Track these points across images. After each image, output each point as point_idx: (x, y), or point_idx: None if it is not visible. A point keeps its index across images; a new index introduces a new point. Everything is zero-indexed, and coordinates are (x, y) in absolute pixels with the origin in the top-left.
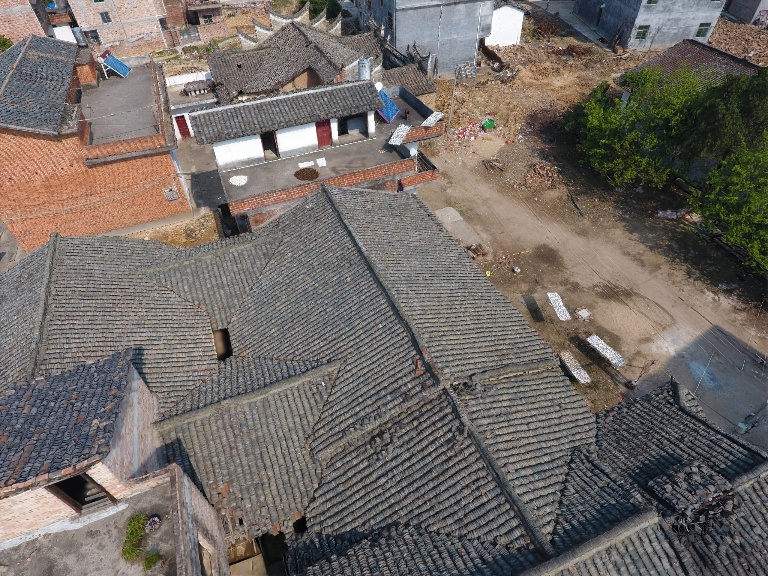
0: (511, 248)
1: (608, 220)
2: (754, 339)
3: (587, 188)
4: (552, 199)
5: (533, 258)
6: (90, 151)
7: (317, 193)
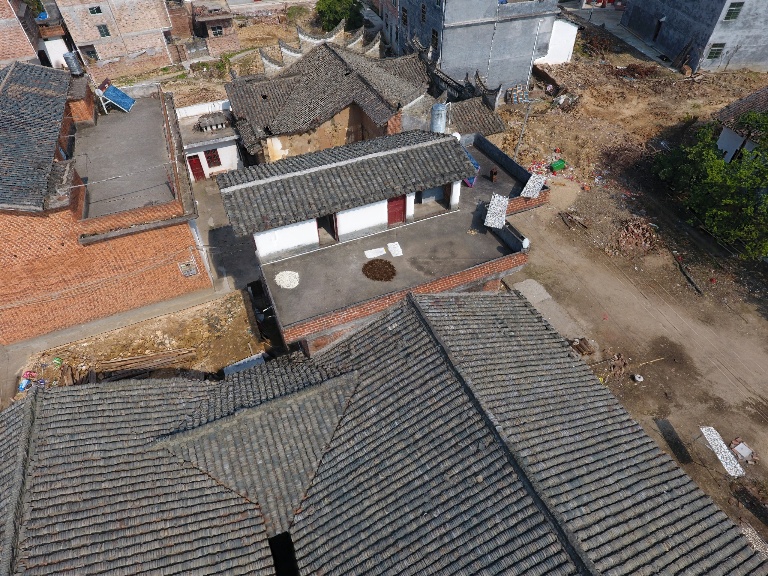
0: (622, 342)
1: (734, 301)
2: None
3: (696, 253)
4: (656, 269)
5: (653, 358)
6: (86, 226)
7: (401, 306)
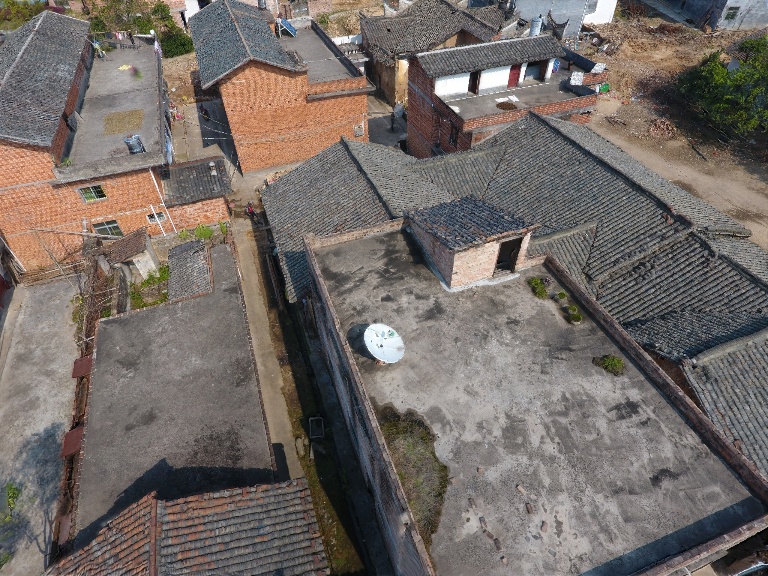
0: None
1: (729, 164)
2: None
3: (704, 140)
4: (676, 147)
5: None
6: (312, 88)
7: (526, 118)
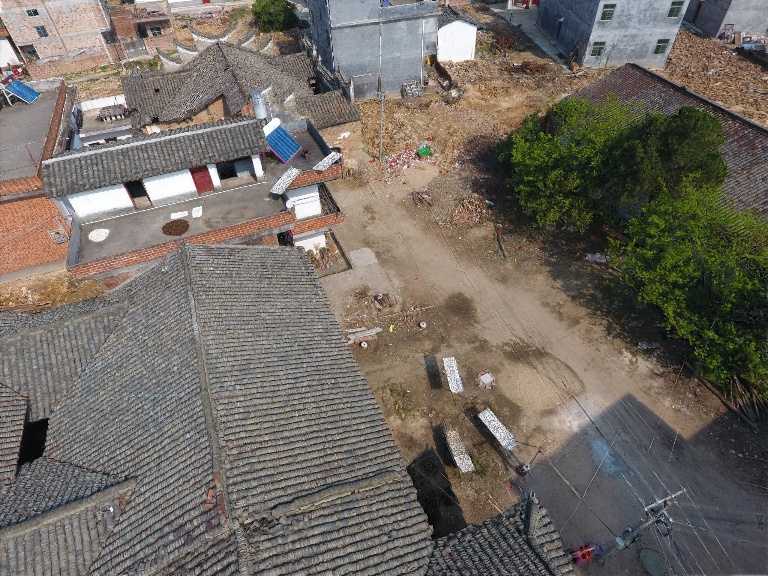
0: (422, 297)
1: (532, 264)
2: (667, 411)
3: (516, 226)
4: (477, 238)
5: (444, 309)
6: None
7: (176, 253)
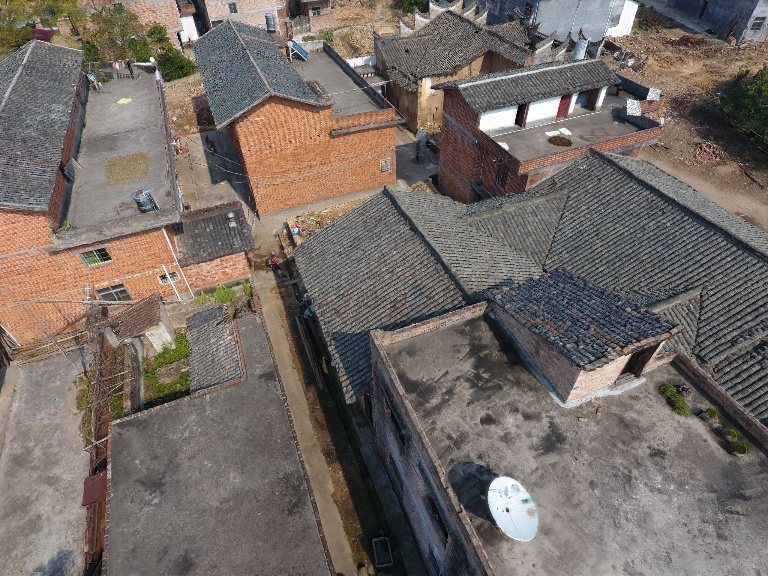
0: None
1: None
2: None
3: (756, 164)
4: (727, 174)
5: None
6: (337, 122)
7: (586, 156)
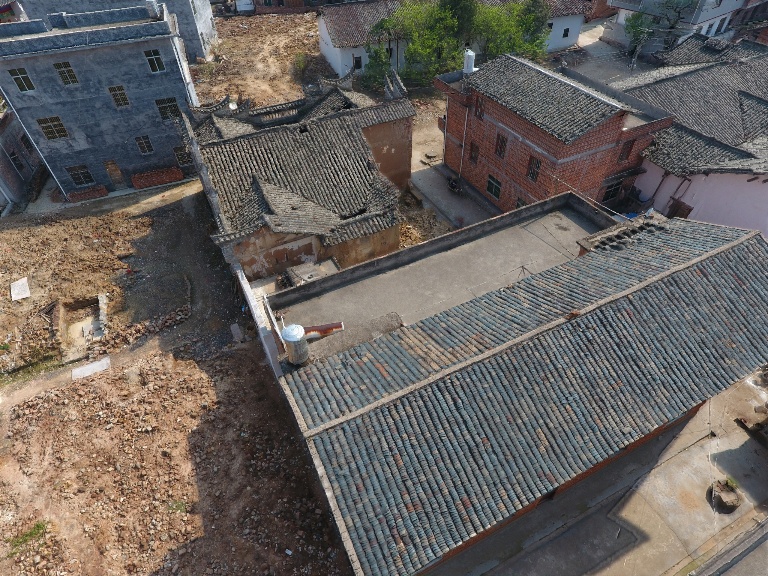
0: None
1: None
2: None
3: (433, 95)
4: None
5: None
6: None
7: None
